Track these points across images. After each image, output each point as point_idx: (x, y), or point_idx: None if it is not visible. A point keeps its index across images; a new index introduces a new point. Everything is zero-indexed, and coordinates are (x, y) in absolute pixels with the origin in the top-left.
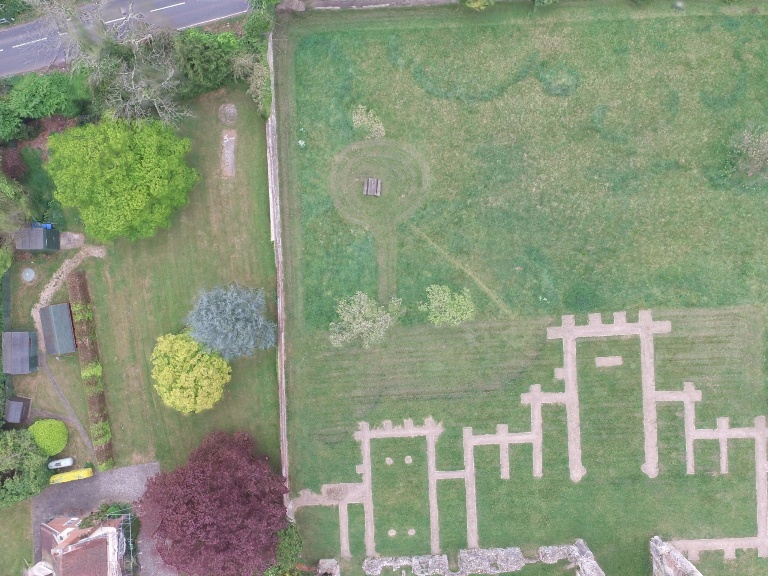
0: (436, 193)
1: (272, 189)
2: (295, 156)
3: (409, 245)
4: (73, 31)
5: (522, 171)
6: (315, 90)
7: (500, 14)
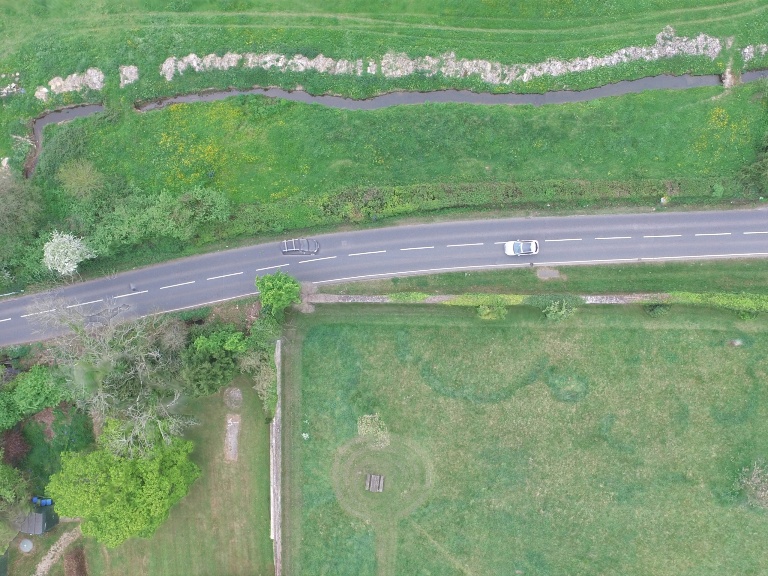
0: (439, 491)
1: (274, 489)
2: (298, 446)
3: (409, 541)
4: (79, 373)
5: (527, 475)
6: (321, 382)
7: (511, 316)
